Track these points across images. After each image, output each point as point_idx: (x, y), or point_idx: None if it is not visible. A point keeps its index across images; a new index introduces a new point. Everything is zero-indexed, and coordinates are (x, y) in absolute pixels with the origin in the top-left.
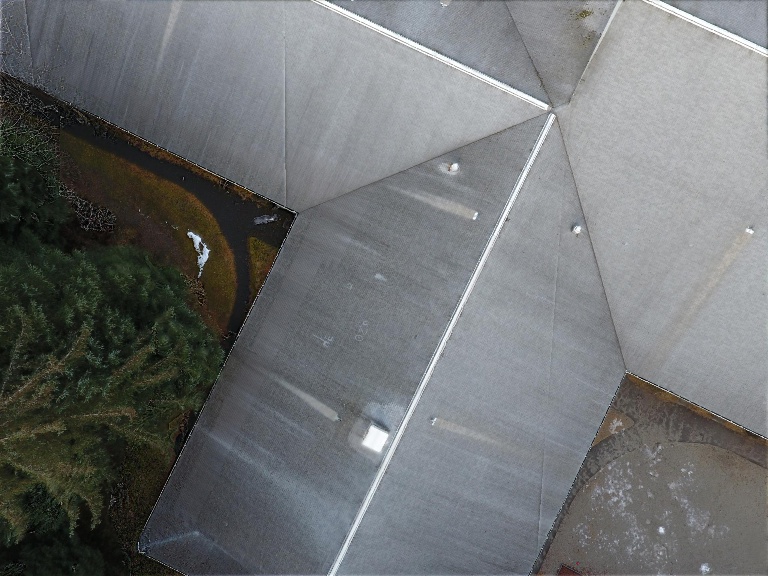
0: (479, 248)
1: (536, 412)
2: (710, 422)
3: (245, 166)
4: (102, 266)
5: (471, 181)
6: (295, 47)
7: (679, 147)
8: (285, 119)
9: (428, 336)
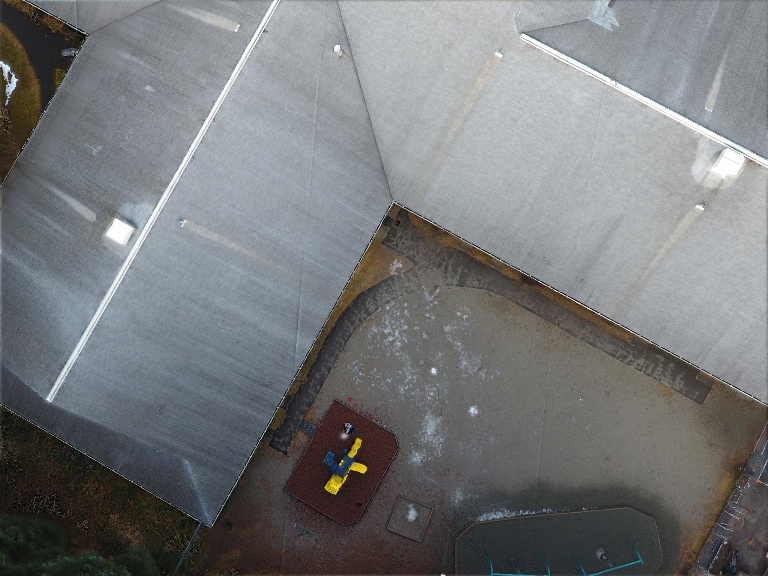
0: (236, 57)
1: (294, 229)
2: (488, 268)
3: None
4: None
5: None
6: None
7: None
8: None
9: (182, 139)
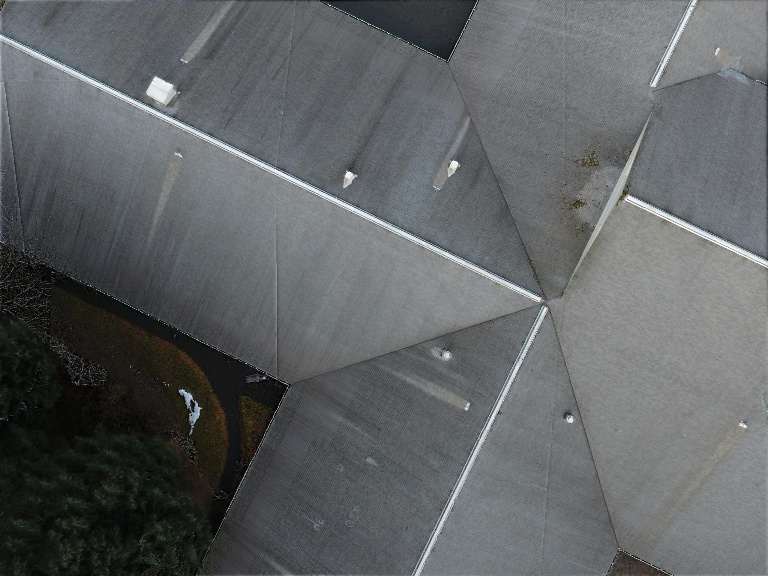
0: (471, 441)
1: None
2: None
3: (236, 338)
4: (93, 423)
5: (463, 369)
6: (287, 230)
7: (672, 344)
8: (277, 297)
9: (419, 529)
